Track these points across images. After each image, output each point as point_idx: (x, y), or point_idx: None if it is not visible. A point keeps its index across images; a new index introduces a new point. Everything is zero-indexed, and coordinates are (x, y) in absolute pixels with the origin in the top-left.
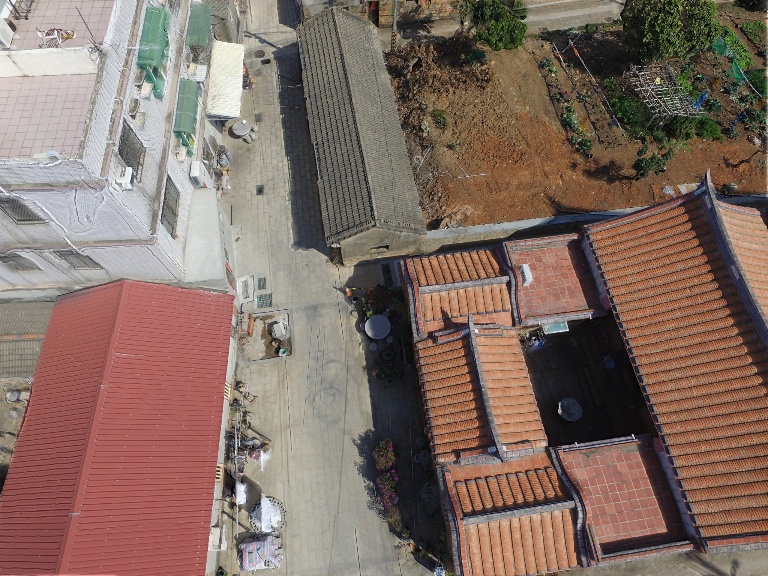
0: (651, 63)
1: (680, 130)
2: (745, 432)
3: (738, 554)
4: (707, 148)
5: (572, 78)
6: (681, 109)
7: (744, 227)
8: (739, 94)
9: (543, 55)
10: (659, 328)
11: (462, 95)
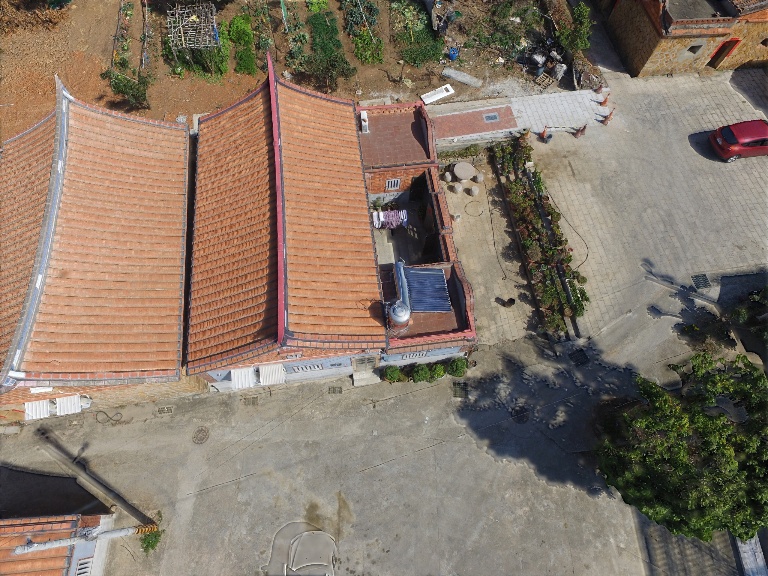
0: (194, 2)
1: (206, 64)
2: (8, 306)
3: (94, 437)
4: (237, 82)
5: (144, 20)
6: (198, 43)
7: (147, 137)
8: (297, 34)
9: (129, 0)
10: (5, 223)
11: (27, 35)
